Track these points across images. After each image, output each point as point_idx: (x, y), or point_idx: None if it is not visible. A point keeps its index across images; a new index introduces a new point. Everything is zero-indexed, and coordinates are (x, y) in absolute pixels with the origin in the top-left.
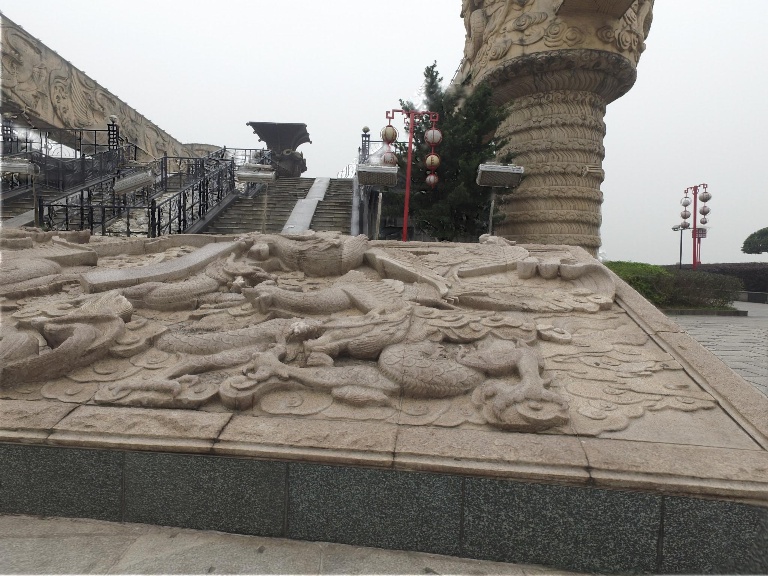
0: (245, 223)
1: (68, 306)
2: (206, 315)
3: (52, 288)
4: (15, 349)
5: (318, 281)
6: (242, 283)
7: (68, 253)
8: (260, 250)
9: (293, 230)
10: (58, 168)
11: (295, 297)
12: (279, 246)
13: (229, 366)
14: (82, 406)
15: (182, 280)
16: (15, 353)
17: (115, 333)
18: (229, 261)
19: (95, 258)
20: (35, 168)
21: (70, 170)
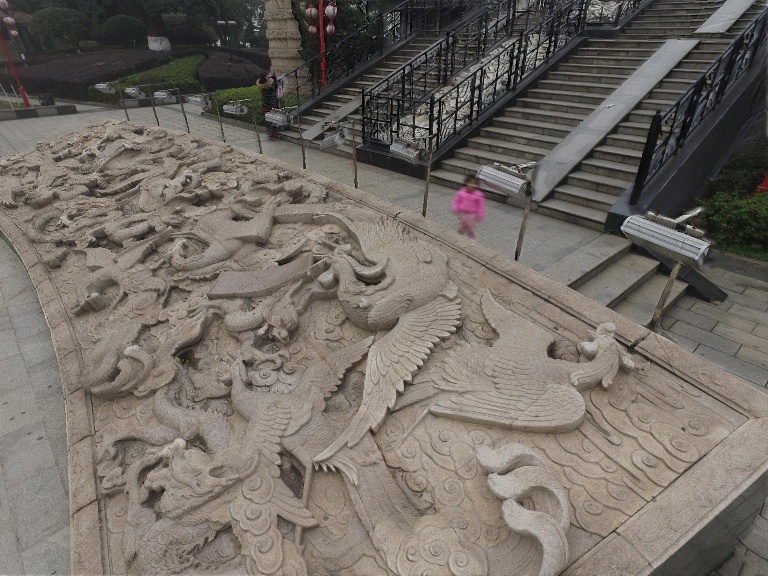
0: (560, 94)
1: (182, 317)
2: (223, 360)
3: (215, 276)
4: (94, 381)
5: (345, 334)
6: (262, 334)
7: (249, 233)
8: (321, 282)
9: (606, 113)
10: (436, 8)
11: (232, 392)
12: (339, 280)
13: (150, 444)
14: (89, 437)
15: (263, 298)
16: (94, 383)
17: (134, 384)
18: (288, 293)
19: (262, 239)
20: (288, 119)
21: (448, 6)
